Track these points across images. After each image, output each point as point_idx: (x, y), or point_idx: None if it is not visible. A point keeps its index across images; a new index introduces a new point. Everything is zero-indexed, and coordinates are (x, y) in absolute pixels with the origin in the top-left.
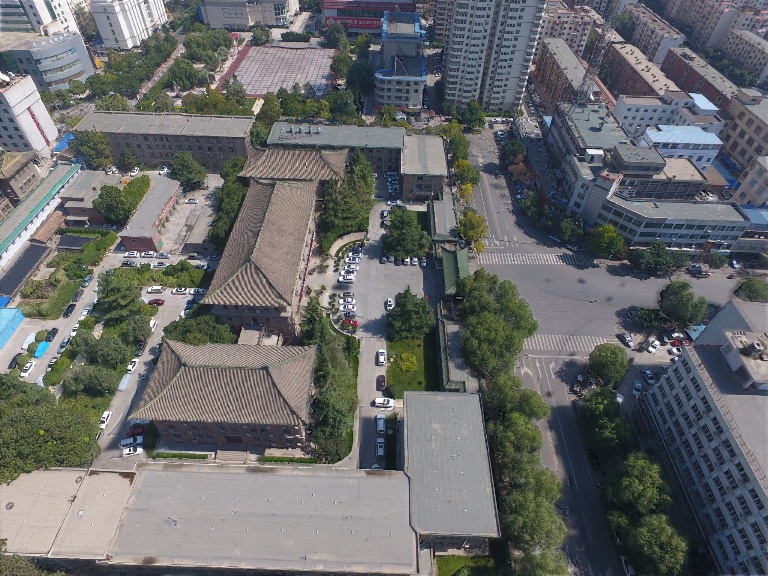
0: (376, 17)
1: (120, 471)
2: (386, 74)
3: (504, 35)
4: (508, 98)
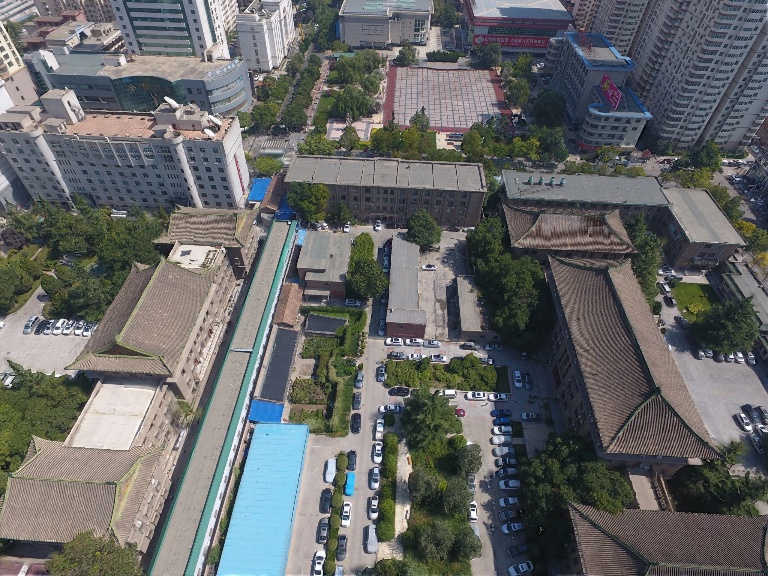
0: (531, 35)
1: None
2: (602, 109)
3: (758, 68)
4: (735, 136)
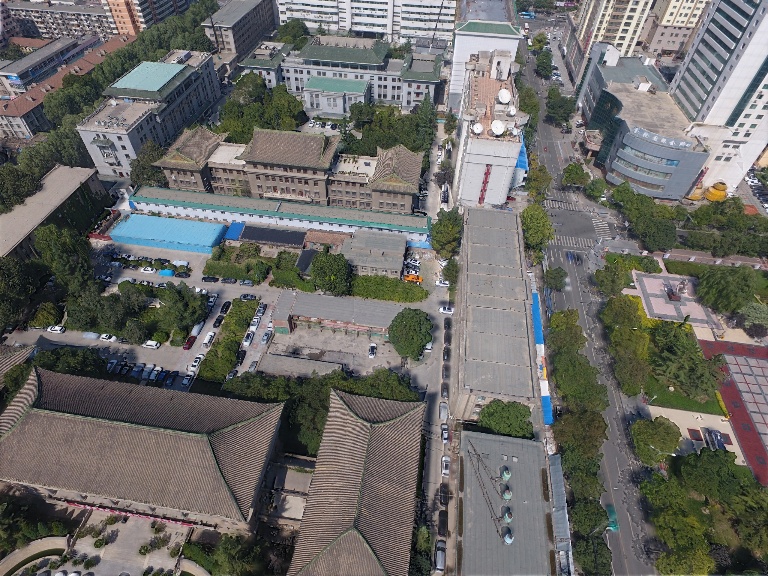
0: None
1: None
2: None
3: None
4: None
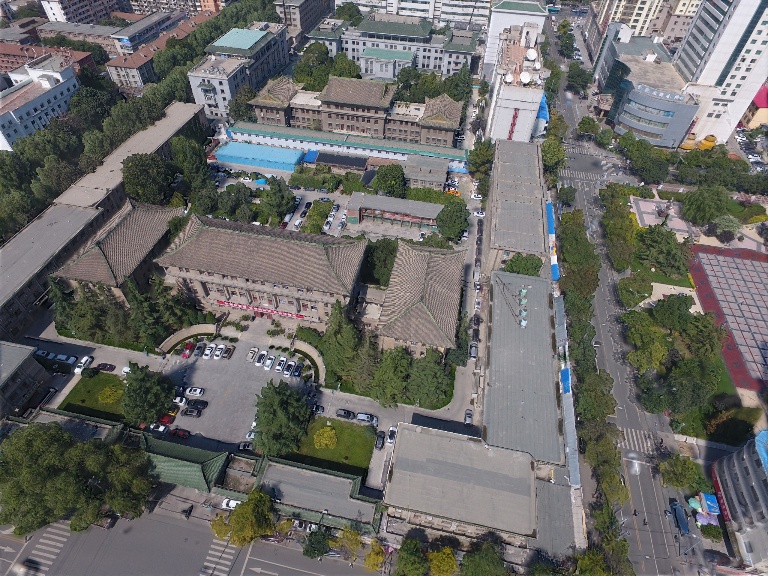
0: None
1: (99, 201)
2: None
3: None
4: None
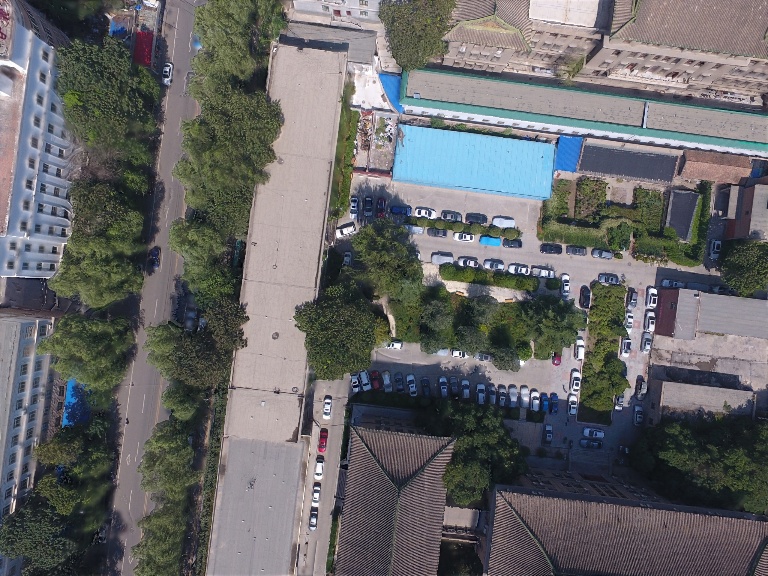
0: None
1: (300, 427)
2: None
3: None
4: None
